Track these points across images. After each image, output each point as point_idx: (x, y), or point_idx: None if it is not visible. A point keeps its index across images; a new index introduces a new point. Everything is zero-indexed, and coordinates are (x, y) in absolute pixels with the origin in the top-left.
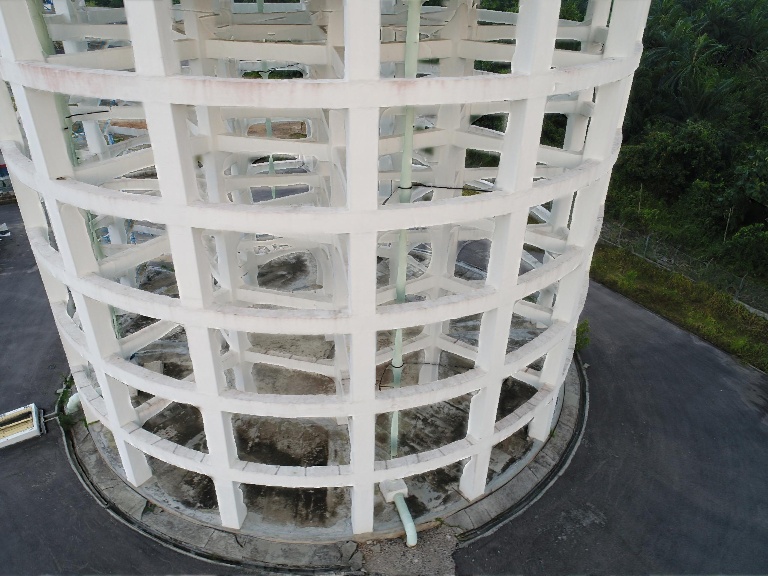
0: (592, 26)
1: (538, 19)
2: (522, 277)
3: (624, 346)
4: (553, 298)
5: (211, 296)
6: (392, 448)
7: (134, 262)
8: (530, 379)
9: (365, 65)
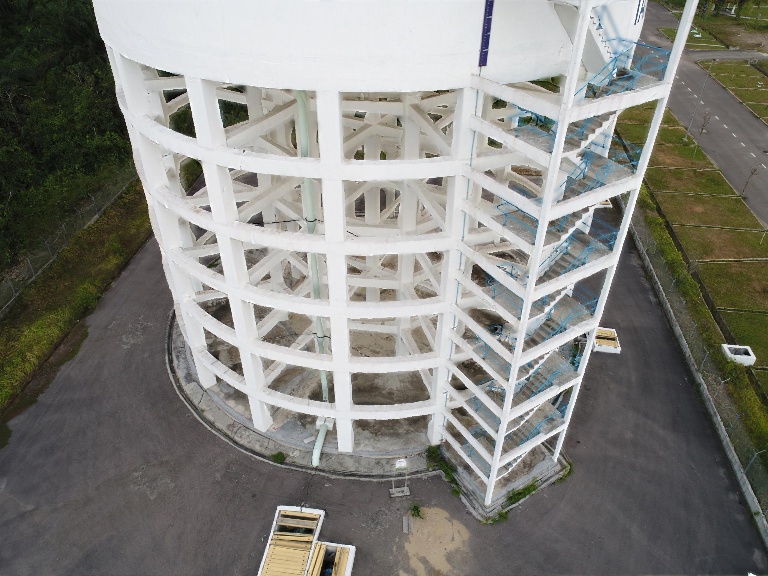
0: None
1: None
2: None
3: None
4: None
5: None
6: None
7: None
8: None
9: None
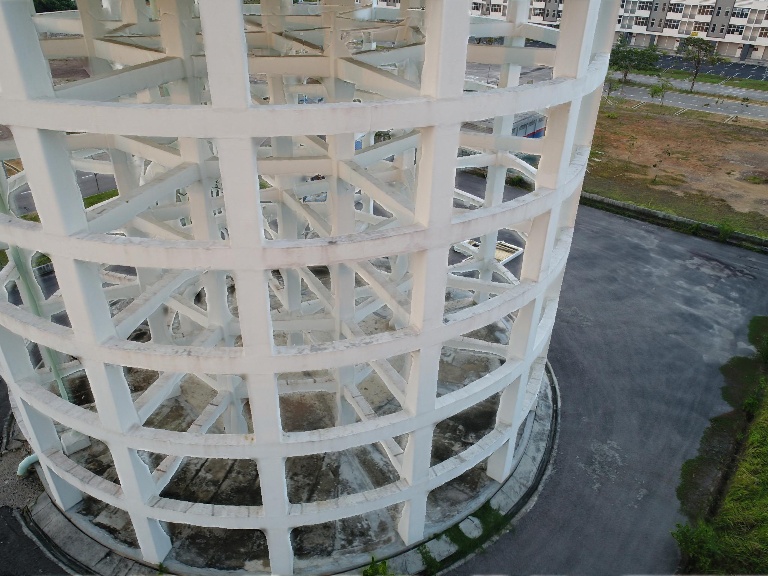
0: (422, 92)
1: None
2: (1, 302)
3: None
4: (529, 557)
5: None
6: None
7: (88, 169)
8: None
9: None
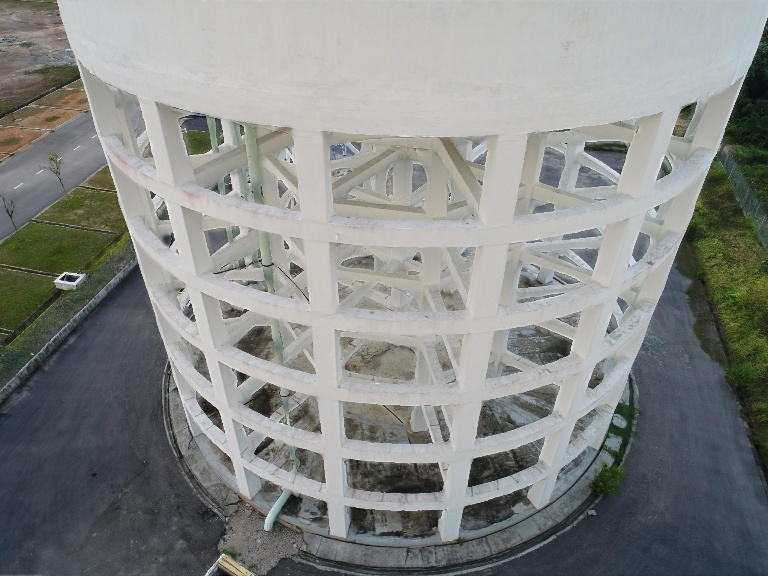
0: (693, 145)
1: (298, 175)
2: (355, 384)
3: (671, 525)
4: (661, 426)
5: (160, 279)
6: (290, 453)
7: None
8: (443, 479)
9: (165, 173)
